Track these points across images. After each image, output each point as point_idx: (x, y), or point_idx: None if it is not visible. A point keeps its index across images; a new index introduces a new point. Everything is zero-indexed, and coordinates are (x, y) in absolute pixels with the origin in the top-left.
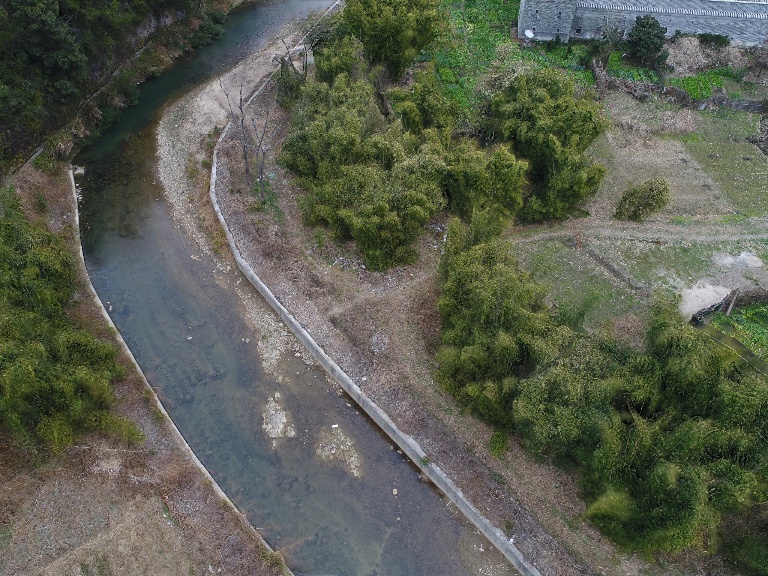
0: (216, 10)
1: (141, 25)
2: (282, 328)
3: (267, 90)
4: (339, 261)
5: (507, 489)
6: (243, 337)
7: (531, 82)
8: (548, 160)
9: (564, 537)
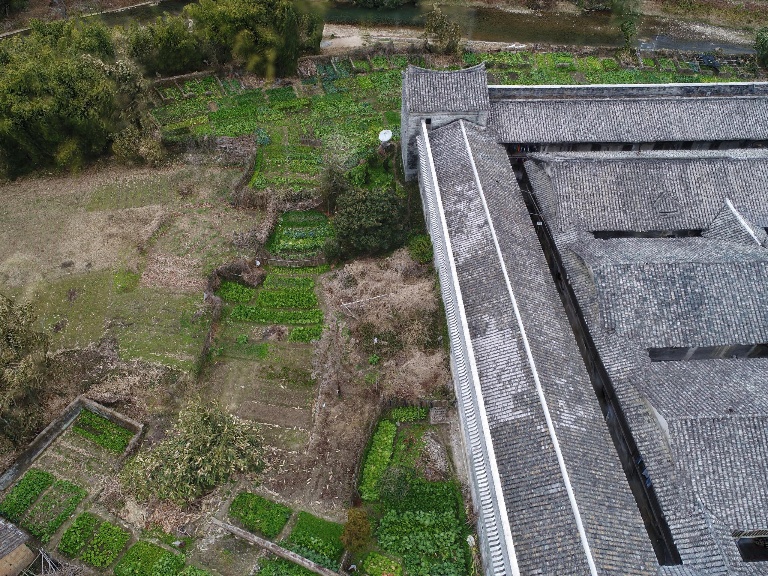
0: None
1: None
2: None
3: None
4: None
5: None
6: None
7: None
8: None
9: None
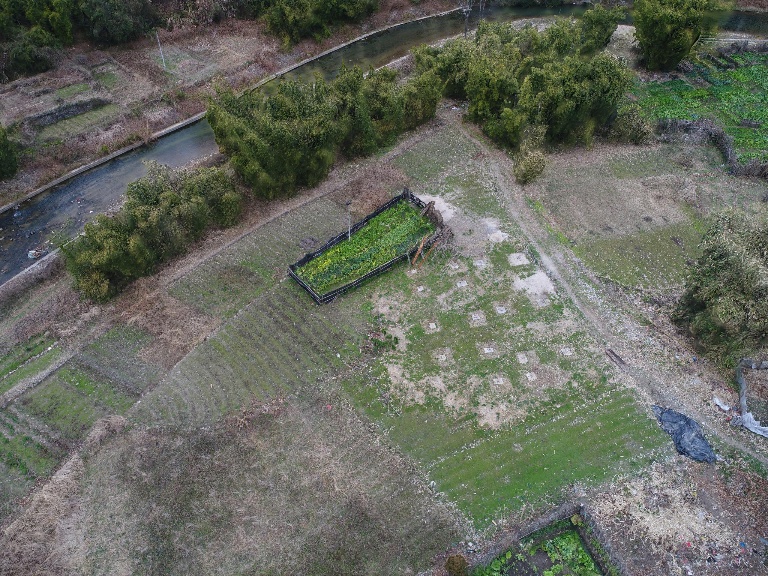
0: (710, 1)
1: None
2: None
3: None
4: None
5: None
6: None
7: None
8: None
9: None
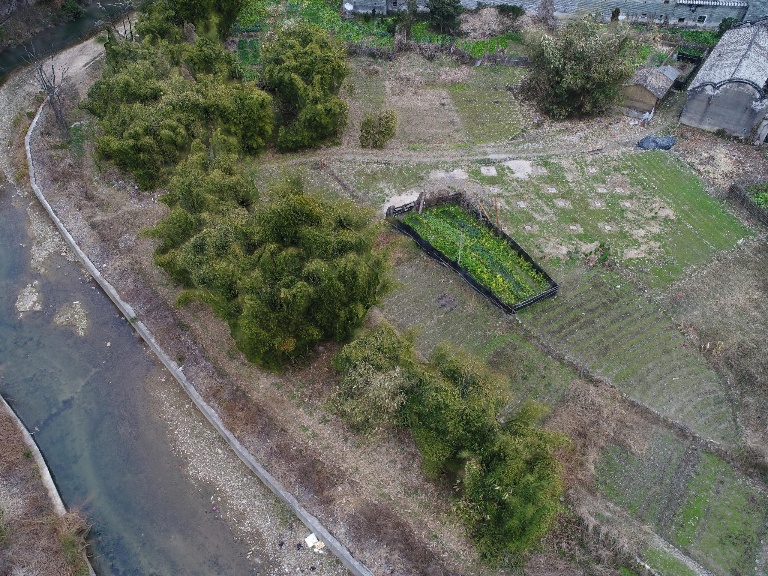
0: None
1: (1, 3)
2: (57, 236)
3: (104, 56)
4: (118, 184)
5: (188, 334)
6: (21, 243)
7: (292, 34)
8: (299, 97)
9: (222, 365)
